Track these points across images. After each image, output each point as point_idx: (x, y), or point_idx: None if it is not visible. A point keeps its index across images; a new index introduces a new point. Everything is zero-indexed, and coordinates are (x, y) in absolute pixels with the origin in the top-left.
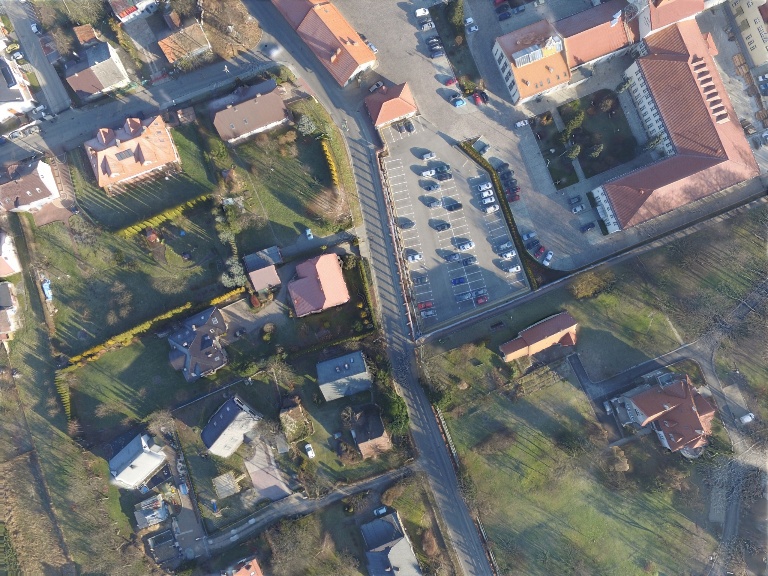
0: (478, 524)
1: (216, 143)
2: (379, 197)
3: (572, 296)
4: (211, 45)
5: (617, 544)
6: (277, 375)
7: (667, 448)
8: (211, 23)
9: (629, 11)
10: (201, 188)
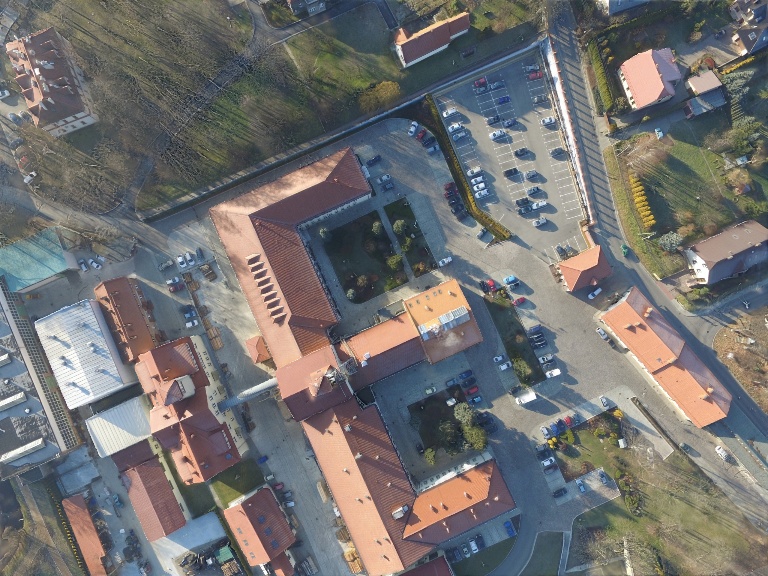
0: None
1: None
2: (588, 178)
3: None
4: (766, 327)
5: None
6: None
7: None
8: (767, 350)
9: (353, 367)
10: (767, 176)
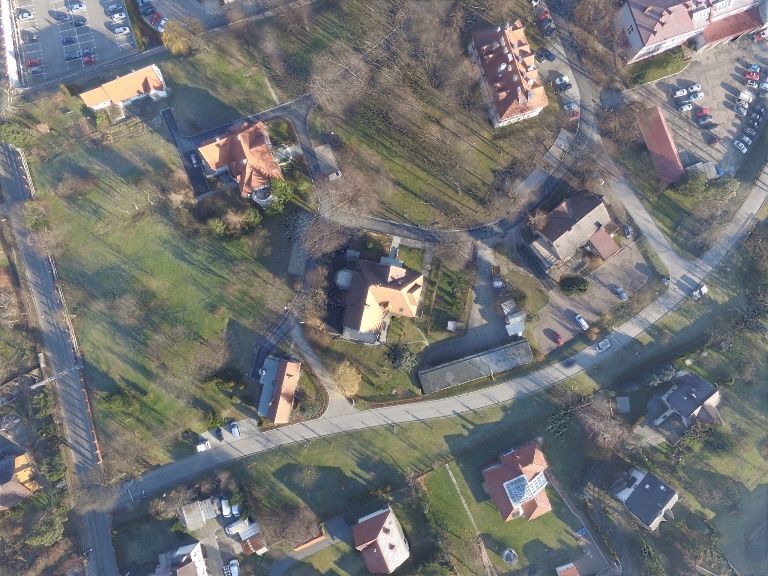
0: (49, 262)
1: None
2: None
3: (169, 52)
4: None
5: (189, 289)
6: None
7: (245, 197)
8: None
9: None
10: None
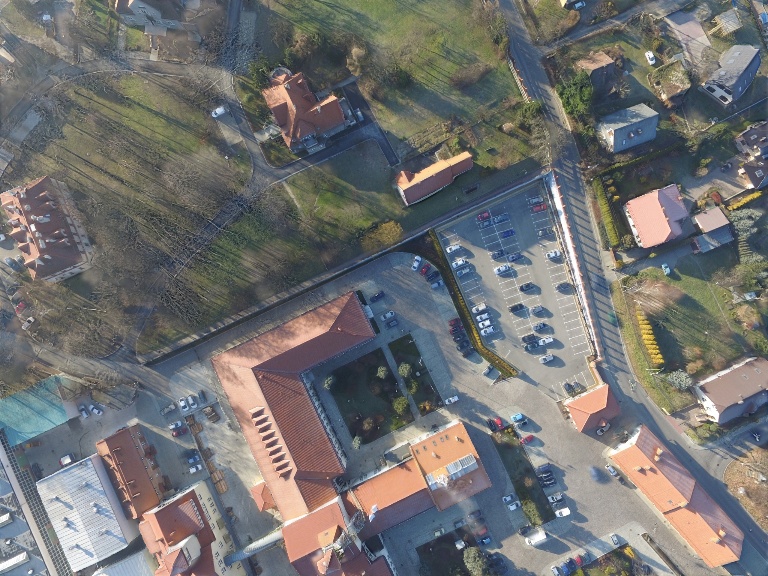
0: None
1: (764, 357)
2: (594, 313)
3: None
4: None
5: None
6: (688, 128)
7: None
8: None
9: (361, 522)
10: None
